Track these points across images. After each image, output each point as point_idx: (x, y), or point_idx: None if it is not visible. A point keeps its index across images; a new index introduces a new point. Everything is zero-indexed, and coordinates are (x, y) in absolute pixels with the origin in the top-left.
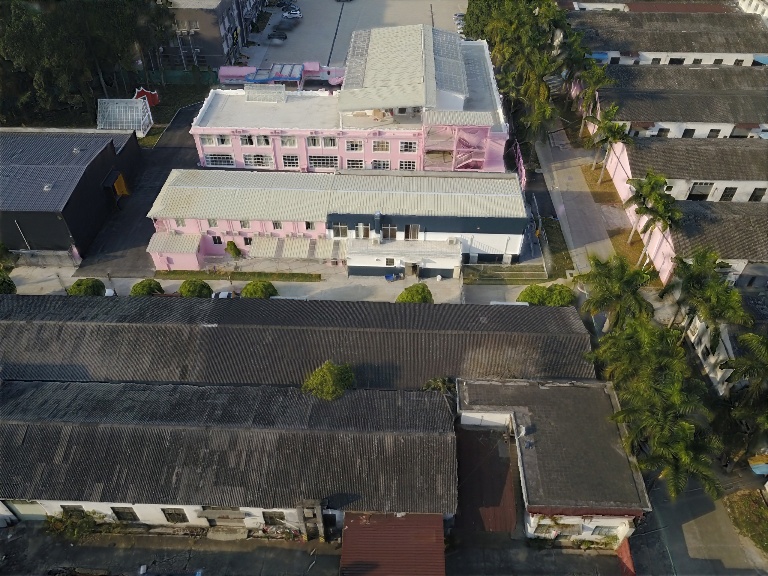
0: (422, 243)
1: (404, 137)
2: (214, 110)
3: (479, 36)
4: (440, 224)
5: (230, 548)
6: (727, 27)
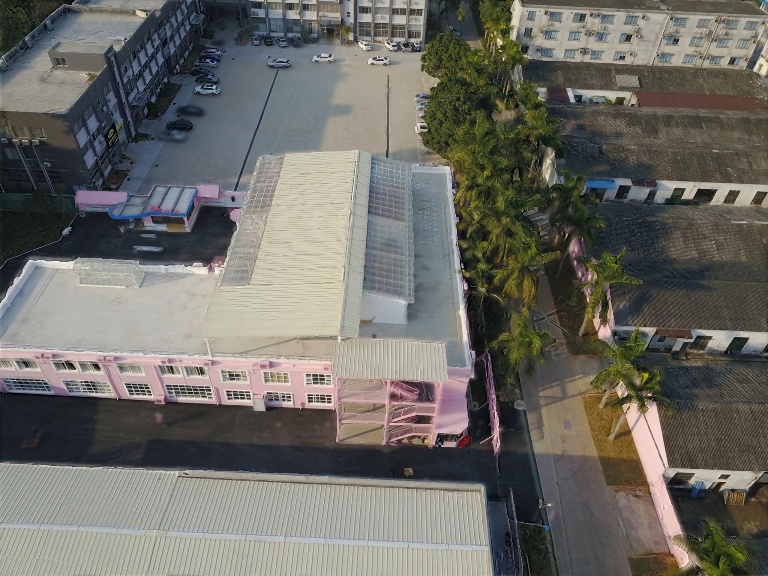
0: None
1: (310, 370)
2: (23, 303)
3: (442, 148)
4: None
5: None
6: (767, 138)
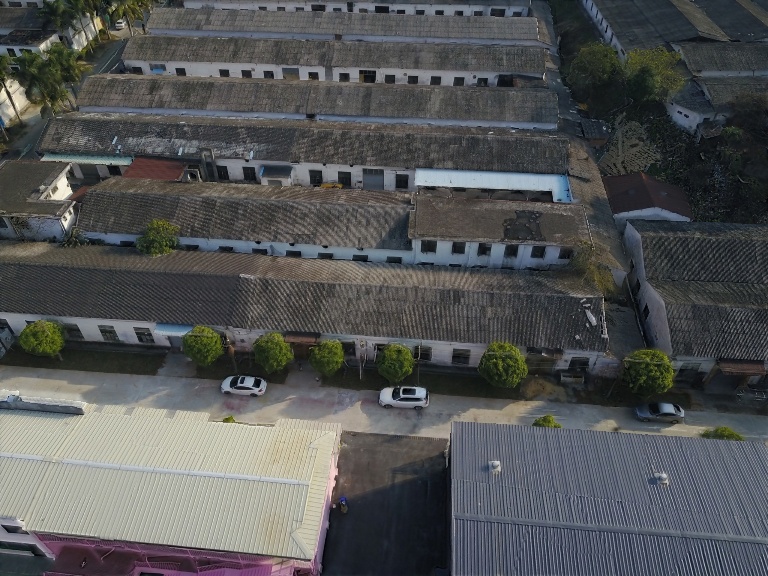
0: None
1: None
2: None
3: None
4: None
5: None
6: None
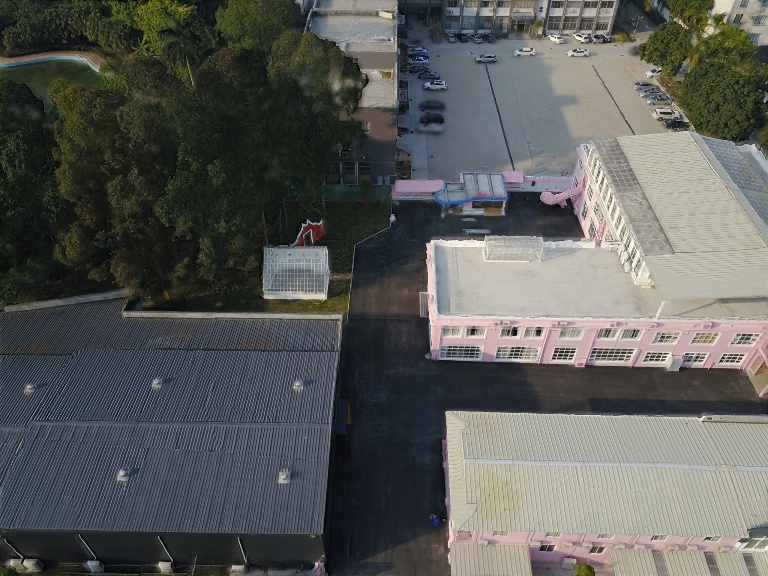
0: None
1: (747, 329)
2: (447, 278)
3: (719, 130)
4: None
5: None
6: None
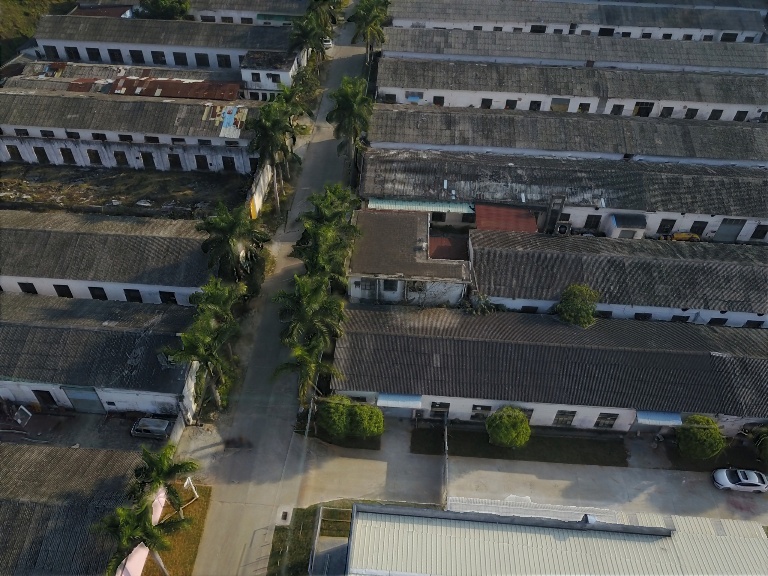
0: None
1: None
2: None
3: None
4: None
5: None
6: None
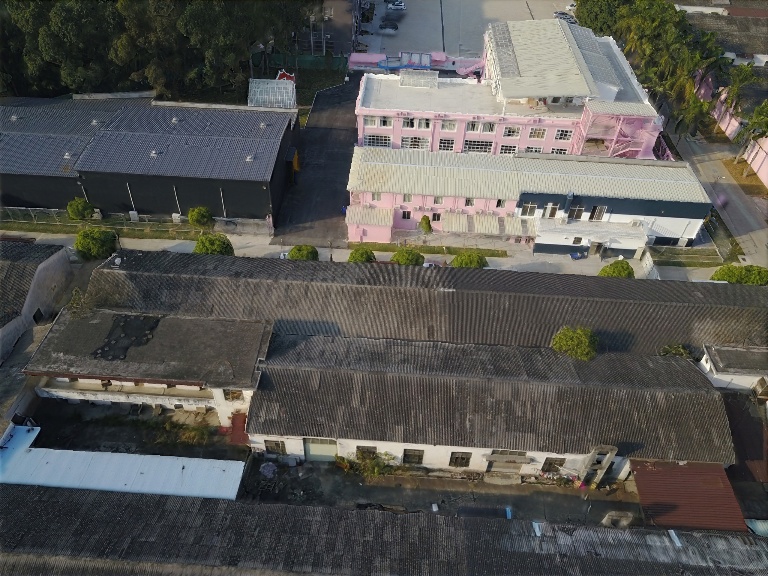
0: (606, 224)
1: (562, 125)
2: (372, 93)
3: (597, 33)
4: (627, 206)
5: (509, 491)
6: None
